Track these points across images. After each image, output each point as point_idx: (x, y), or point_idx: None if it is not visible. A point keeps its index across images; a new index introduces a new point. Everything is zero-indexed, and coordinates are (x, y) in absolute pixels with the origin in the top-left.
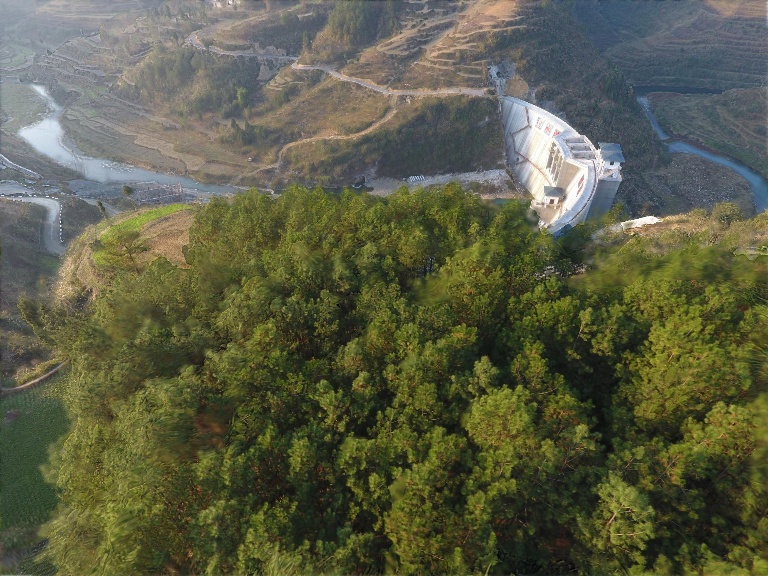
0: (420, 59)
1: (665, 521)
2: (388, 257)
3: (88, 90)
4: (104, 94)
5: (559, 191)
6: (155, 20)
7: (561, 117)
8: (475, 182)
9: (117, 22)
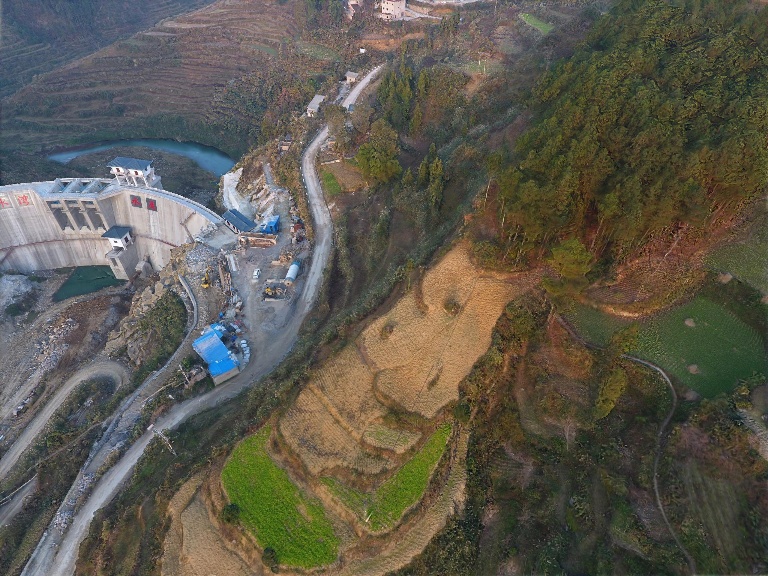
0: None
1: None
2: None
3: None
4: None
5: (121, 227)
6: None
7: None
8: (10, 307)
9: None
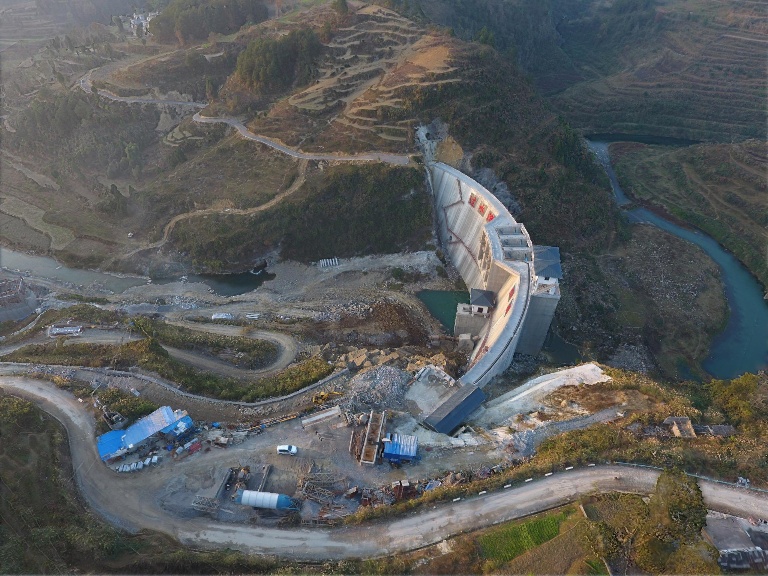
0: (338, 115)
1: None
2: None
3: None
4: None
5: (488, 298)
6: (55, 53)
7: (501, 188)
8: (397, 269)
9: (15, 53)
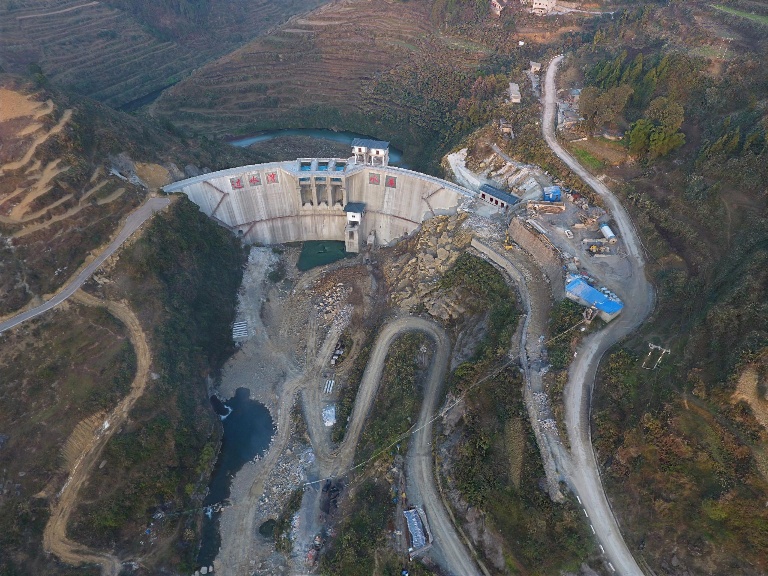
0: (4, 233)
1: None
2: None
3: None
4: None
5: (357, 203)
6: None
7: None
8: (272, 274)
9: None
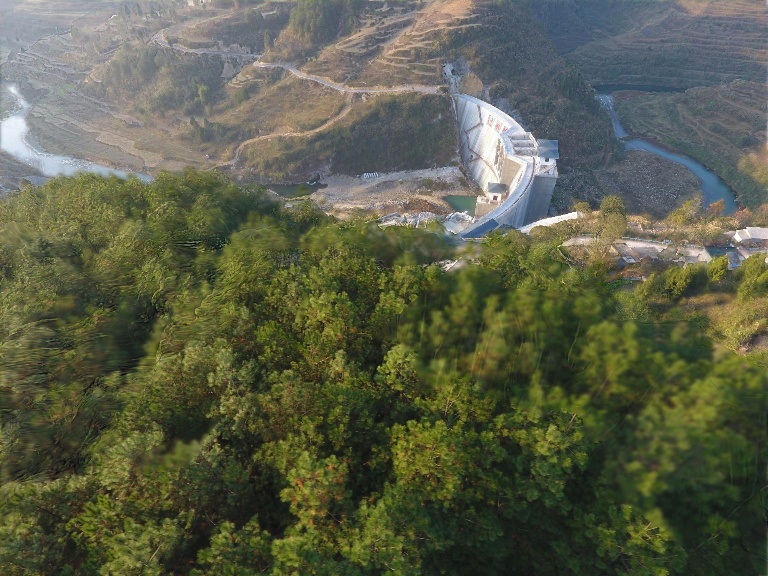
0: (377, 57)
1: (28, 452)
2: (78, 235)
3: (57, 88)
4: (72, 91)
5: (502, 187)
6: (126, 18)
7: (515, 115)
8: (427, 179)
9: (90, 20)
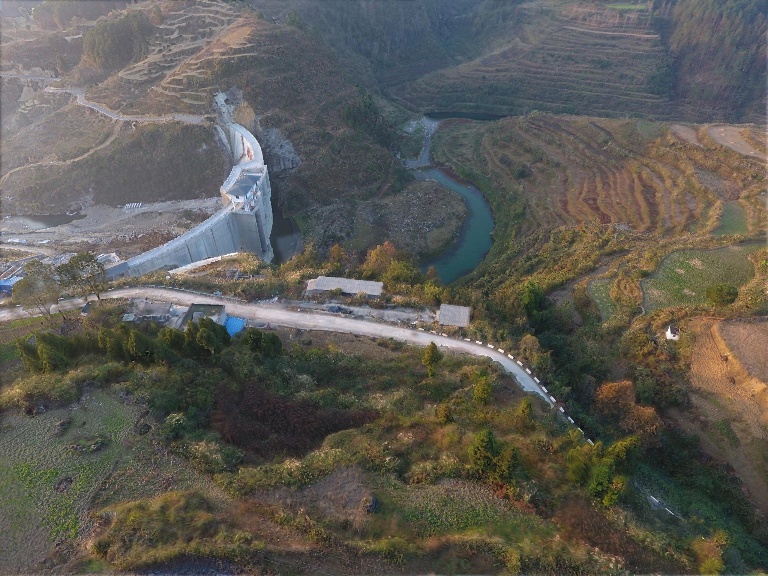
0: (157, 84)
1: None
2: None
3: None
4: None
5: None
6: None
7: (287, 145)
8: (186, 210)
9: None
